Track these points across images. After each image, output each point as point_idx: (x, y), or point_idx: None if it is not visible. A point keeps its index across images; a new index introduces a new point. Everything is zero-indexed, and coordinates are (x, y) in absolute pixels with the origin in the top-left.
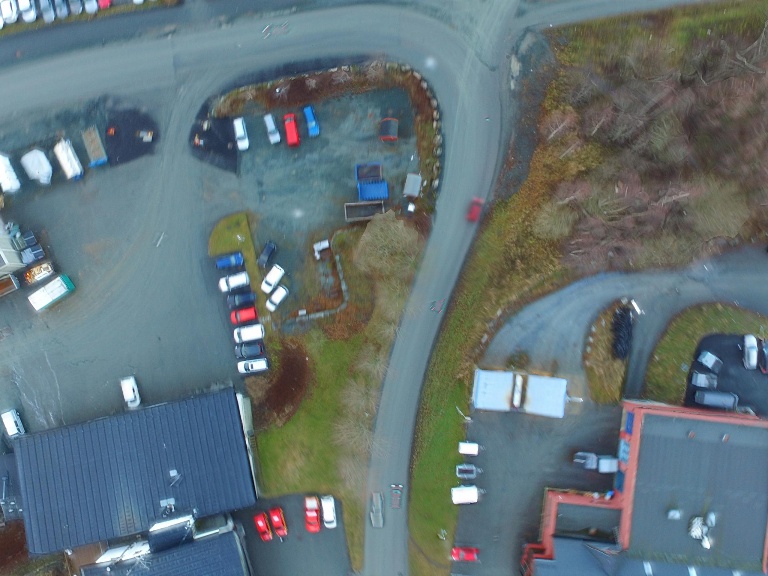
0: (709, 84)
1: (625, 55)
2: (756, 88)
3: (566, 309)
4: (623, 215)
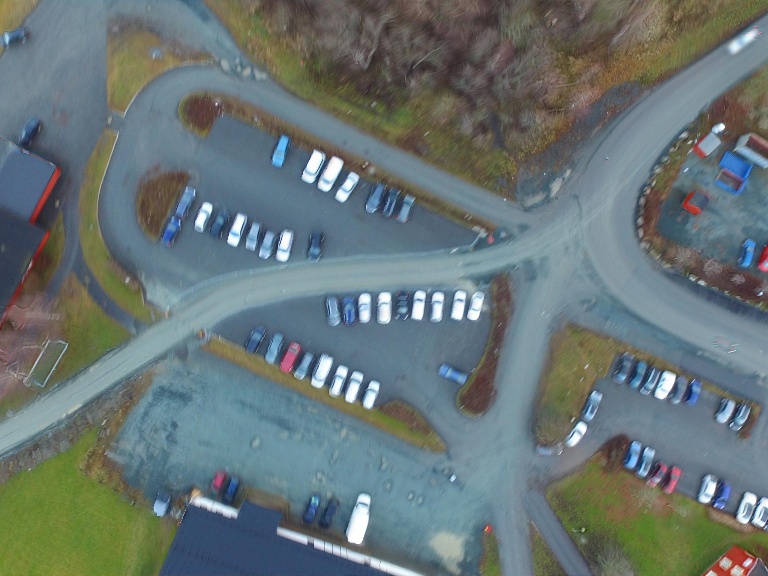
0: (440, 46)
1: (463, 132)
2: (420, 7)
3: None
4: None
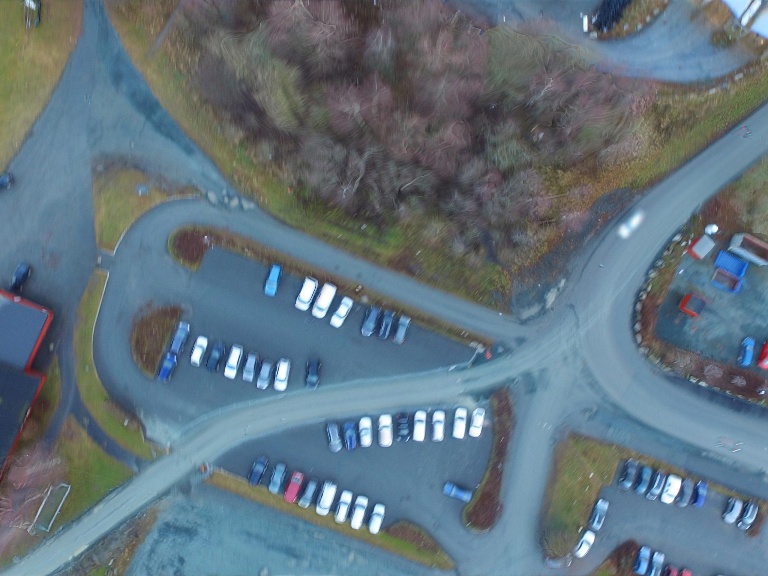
0: (427, 174)
1: (454, 250)
2: (405, 142)
3: (652, 59)
4: (563, 108)
